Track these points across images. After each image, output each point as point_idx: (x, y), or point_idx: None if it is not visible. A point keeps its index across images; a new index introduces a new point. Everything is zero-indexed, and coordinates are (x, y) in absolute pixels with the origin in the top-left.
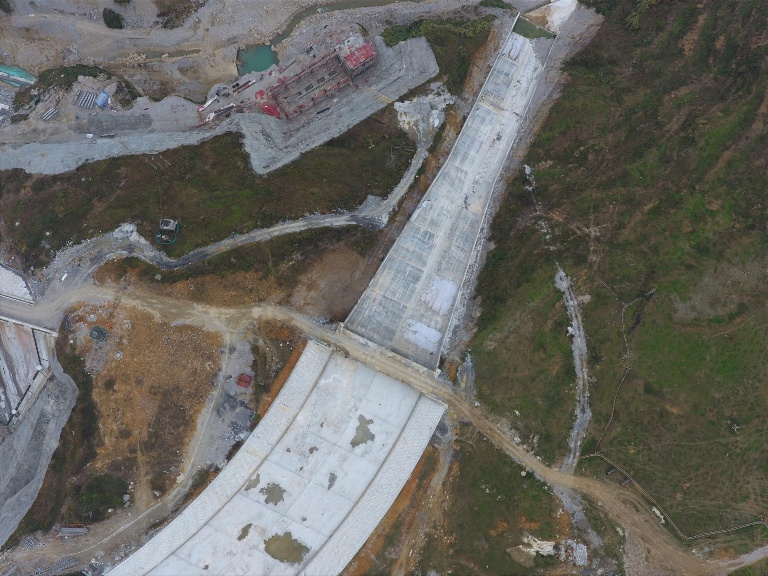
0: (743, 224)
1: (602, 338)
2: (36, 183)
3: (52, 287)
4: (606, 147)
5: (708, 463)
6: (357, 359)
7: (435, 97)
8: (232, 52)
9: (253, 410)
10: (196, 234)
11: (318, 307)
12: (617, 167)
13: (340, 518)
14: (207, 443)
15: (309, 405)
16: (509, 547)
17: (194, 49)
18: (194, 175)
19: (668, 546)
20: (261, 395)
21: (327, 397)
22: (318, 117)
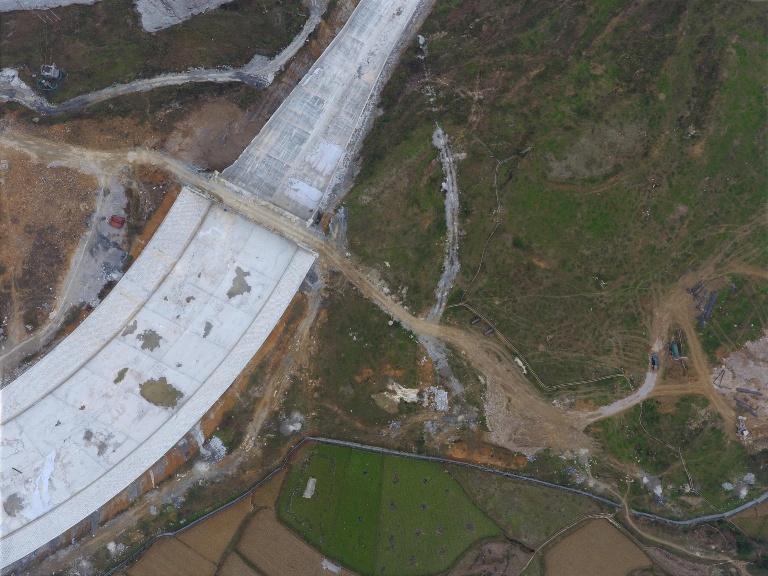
0: (625, 88)
1: (474, 193)
2: None
3: None
4: (501, 19)
5: (572, 316)
6: (230, 206)
7: None
8: None
9: (125, 251)
10: (79, 83)
11: (193, 153)
12: (509, 36)
13: (214, 365)
14: (80, 282)
15: (187, 256)
16: (374, 393)
17: None
18: (83, 30)
19: (529, 395)
20: (134, 237)
21: (205, 248)
22: None
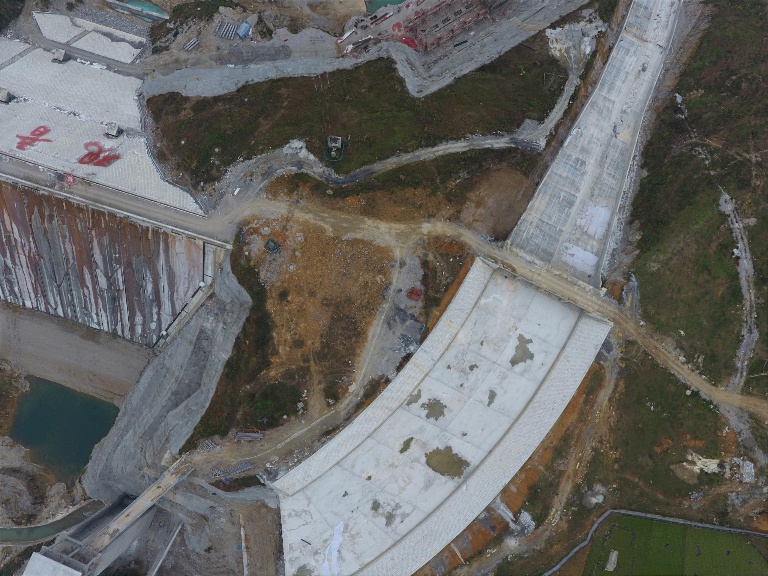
0: None
1: None
2: (197, 104)
3: (225, 201)
4: (759, 76)
5: None
6: (524, 276)
7: (587, 24)
8: None
9: (423, 323)
10: (361, 153)
11: (486, 224)
12: None
13: (499, 434)
14: (378, 354)
15: (469, 323)
16: (673, 464)
17: None
18: (353, 97)
19: None
20: (431, 309)
21: (487, 316)
22: (456, 49)
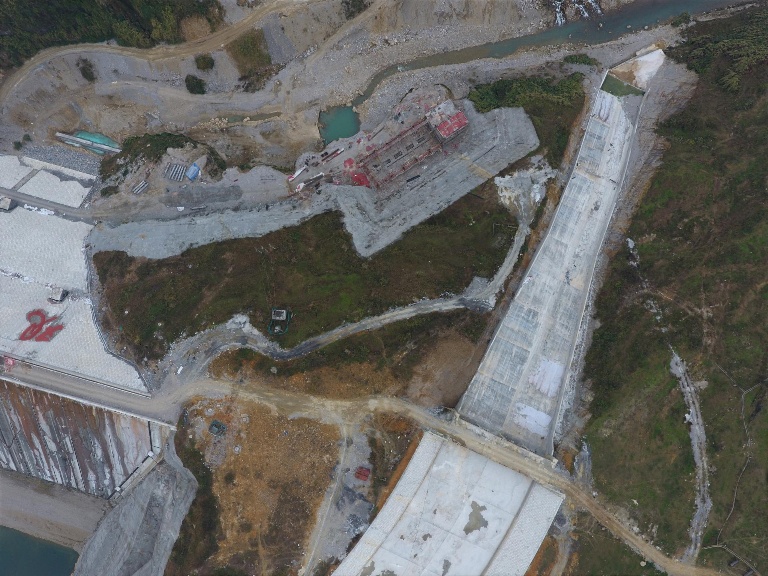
0: None
1: (721, 426)
2: (141, 269)
3: (168, 380)
4: (711, 219)
5: None
6: (474, 450)
7: (536, 171)
8: (314, 115)
9: (372, 503)
10: (307, 323)
11: (434, 398)
12: (725, 242)
13: None
14: (327, 536)
15: (422, 492)
16: None
17: (275, 112)
18: (299, 259)
19: None
20: (379, 488)
21: (439, 484)
22: (408, 186)
